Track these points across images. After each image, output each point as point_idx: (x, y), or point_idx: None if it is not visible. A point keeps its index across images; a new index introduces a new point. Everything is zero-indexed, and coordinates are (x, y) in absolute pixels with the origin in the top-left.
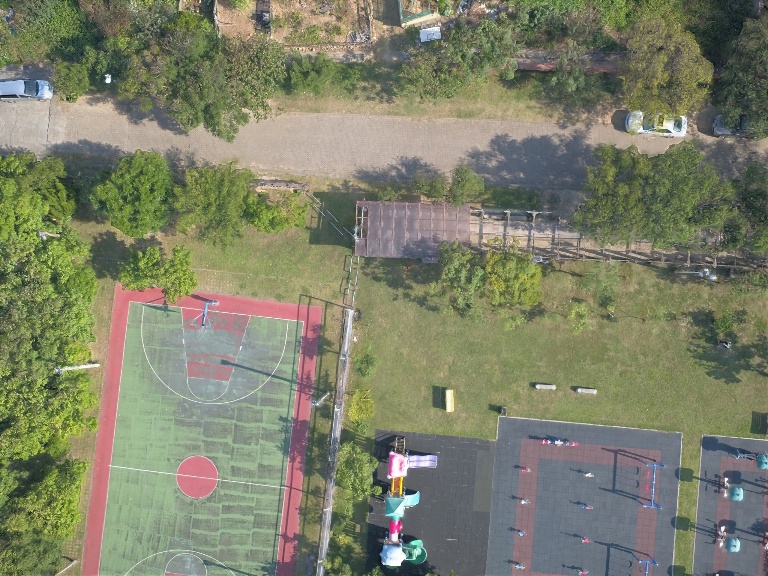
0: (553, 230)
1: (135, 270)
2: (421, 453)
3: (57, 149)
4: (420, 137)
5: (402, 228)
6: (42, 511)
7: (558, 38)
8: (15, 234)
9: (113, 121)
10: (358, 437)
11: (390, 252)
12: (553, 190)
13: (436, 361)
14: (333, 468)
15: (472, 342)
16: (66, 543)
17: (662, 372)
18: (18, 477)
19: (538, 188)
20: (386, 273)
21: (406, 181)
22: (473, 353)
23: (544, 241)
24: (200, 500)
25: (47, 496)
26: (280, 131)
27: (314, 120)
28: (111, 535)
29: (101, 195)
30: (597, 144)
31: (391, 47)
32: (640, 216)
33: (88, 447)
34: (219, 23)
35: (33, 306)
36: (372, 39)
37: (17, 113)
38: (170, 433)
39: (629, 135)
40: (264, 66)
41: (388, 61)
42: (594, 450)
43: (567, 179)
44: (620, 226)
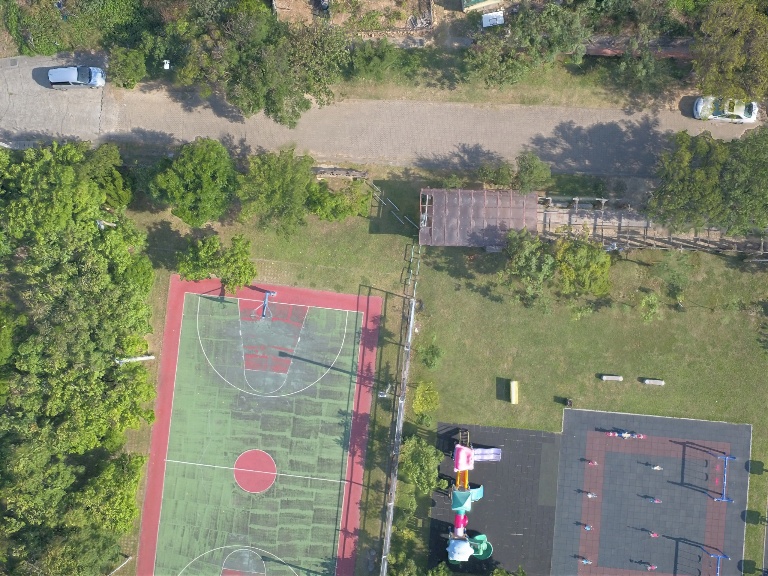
0: (619, 218)
1: (194, 260)
2: (485, 446)
3: (110, 137)
4: (483, 124)
5: (468, 216)
6: (101, 506)
7: (624, 23)
8: (73, 223)
9: (167, 109)
10: (420, 430)
11: (455, 241)
12: (619, 177)
13: (500, 352)
14: (397, 461)
15: (536, 333)
16: (121, 539)
17: (731, 363)
18: (74, 471)
19: (604, 175)
20: (448, 263)
21: (468, 169)
22: (537, 344)
23: (610, 229)
24: (258, 495)
25: (106, 491)
26: (339, 118)
27: (374, 107)
28: (167, 531)
29: (161, 183)
30: (664, 130)
31: (452, 32)
32: (717, 202)
33: (143, 441)
34: (276, 8)
35: (90, 297)
36: (433, 24)
37: (68, 101)
38: (227, 426)
39: (697, 121)
40: (328, 50)
41: (449, 47)
42: (662, 442)
43: (633, 166)
44: (696, 213)
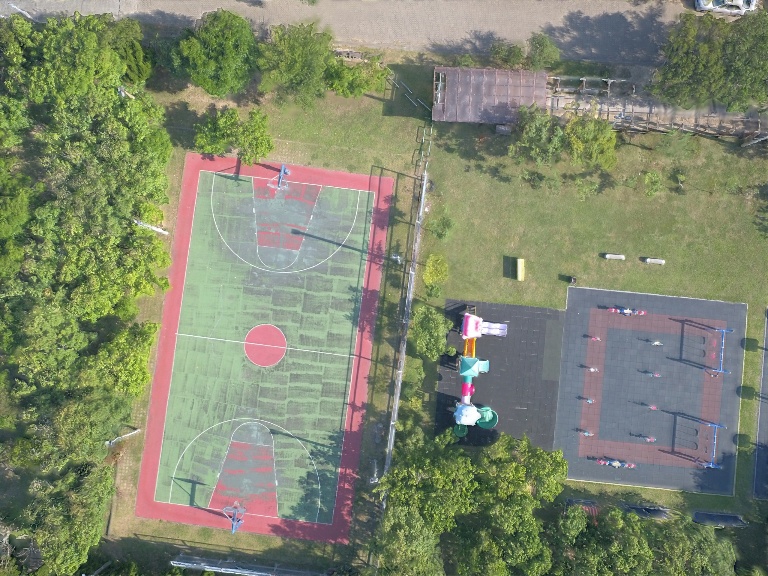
0: (623, 104)
1: (212, 131)
2: (491, 322)
3: None
4: (494, 12)
5: (479, 93)
6: (115, 365)
7: None
8: (94, 87)
9: None
10: (428, 306)
11: (467, 116)
12: (624, 66)
13: (507, 232)
14: (406, 331)
15: (543, 213)
16: None
17: (728, 244)
18: (87, 337)
19: (609, 63)
20: (458, 145)
21: (479, 55)
22: (543, 224)
23: (614, 115)
24: (268, 368)
25: (119, 352)
26: (355, 5)
27: None
28: (176, 403)
29: (183, 50)
30: (667, 22)
31: None
32: (719, 75)
33: (154, 315)
34: None
35: (108, 164)
36: None
37: None
38: (239, 301)
39: (698, 14)
40: None
41: None
42: (662, 320)
43: (637, 55)
44: (698, 86)
